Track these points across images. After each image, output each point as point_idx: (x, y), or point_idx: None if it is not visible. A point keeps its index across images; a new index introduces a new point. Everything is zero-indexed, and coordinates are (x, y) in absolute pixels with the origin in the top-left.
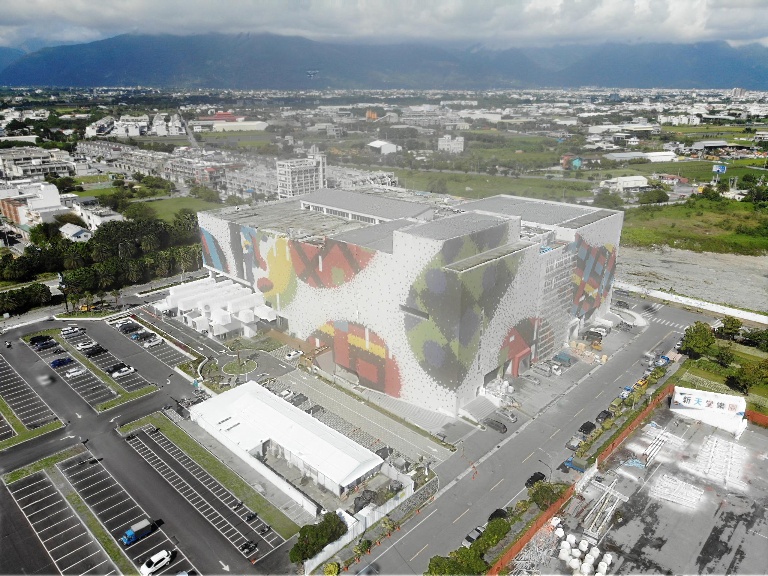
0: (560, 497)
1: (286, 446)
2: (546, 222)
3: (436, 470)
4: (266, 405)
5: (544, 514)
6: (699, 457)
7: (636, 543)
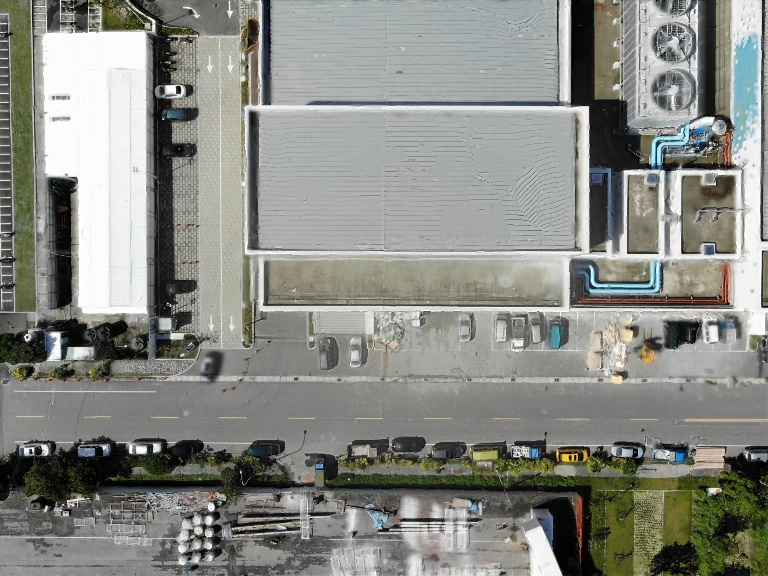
0: (242, 492)
1: (80, 207)
2: None
3: (203, 352)
4: (106, 118)
5: (208, 491)
6: (446, 570)
7: (254, 566)
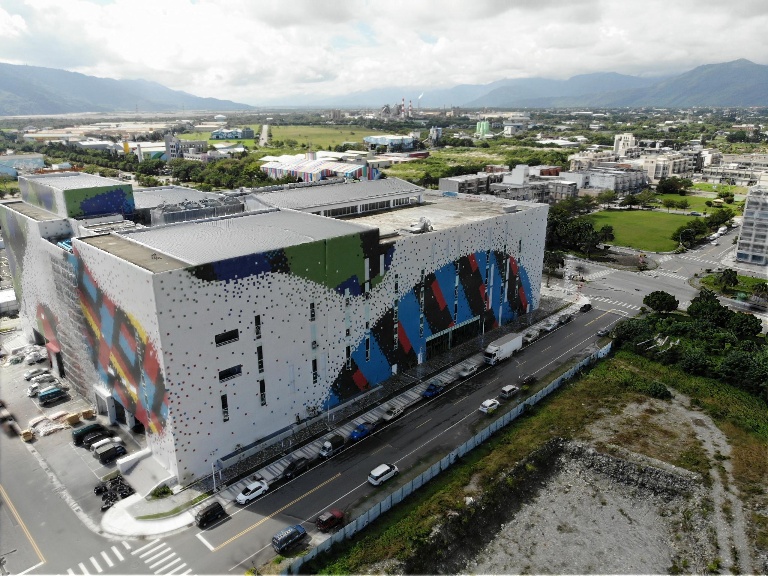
0: None
1: None
2: (147, 234)
3: None
4: None
5: None
6: None
7: None
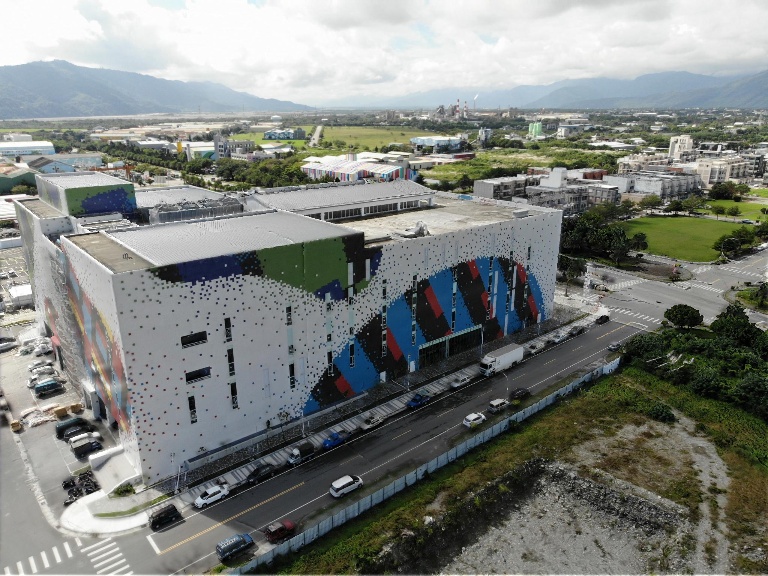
0: None
1: None
2: (134, 233)
3: None
4: None
5: None
6: None
7: None
